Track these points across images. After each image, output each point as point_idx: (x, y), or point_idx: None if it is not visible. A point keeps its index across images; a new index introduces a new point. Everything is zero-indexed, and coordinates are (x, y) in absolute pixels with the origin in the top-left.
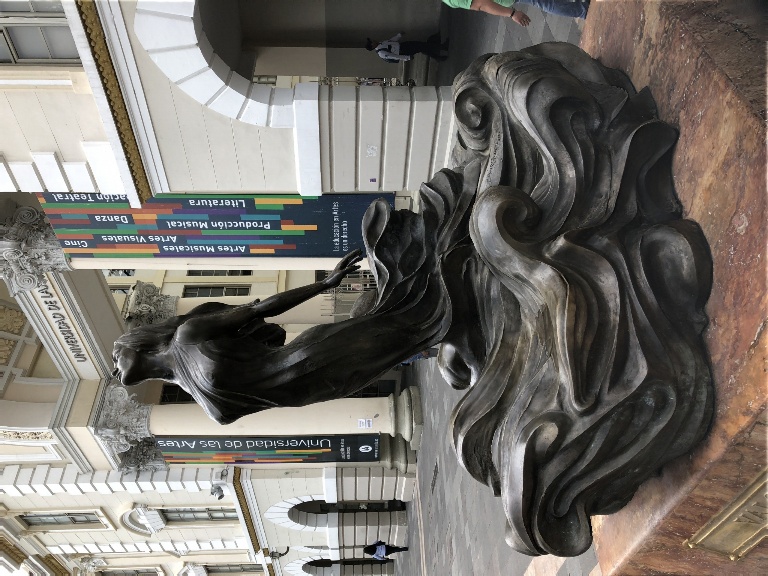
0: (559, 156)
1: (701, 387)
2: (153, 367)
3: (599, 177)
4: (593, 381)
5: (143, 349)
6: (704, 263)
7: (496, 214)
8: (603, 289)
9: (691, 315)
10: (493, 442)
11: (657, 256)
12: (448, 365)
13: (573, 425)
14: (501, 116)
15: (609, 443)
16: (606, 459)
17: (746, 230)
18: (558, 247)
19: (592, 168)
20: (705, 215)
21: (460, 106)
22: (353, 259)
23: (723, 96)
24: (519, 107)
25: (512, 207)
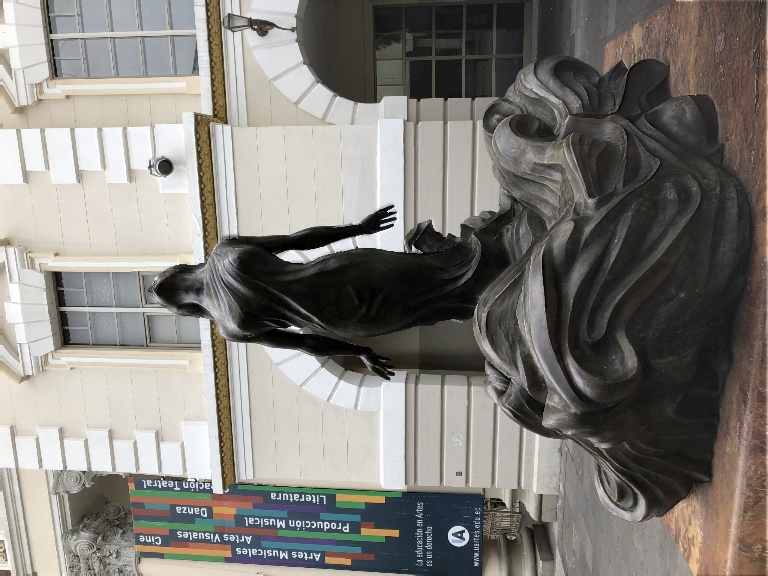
0: (566, 98)
1: (729, 188)
2: (187, 281)
3: (604, 104)
4: (607, 185)
5: (182, 270)
6: (705, 103)
7: (509, 123)
8: (611, 140)
9: (706, 150)
10: (518, 304)
11: (662, 120)
12: None
13: (590, 219)
14: (521, 112)
15: (634, 235)
16: (636, 260)
17: (724, 39)
18: (565, 125)
19: (596, 98)
20: (699, 81)
21: (488, 122)
22: (388, 217)
23: None
24: (529, 78)
25: (524, 120)
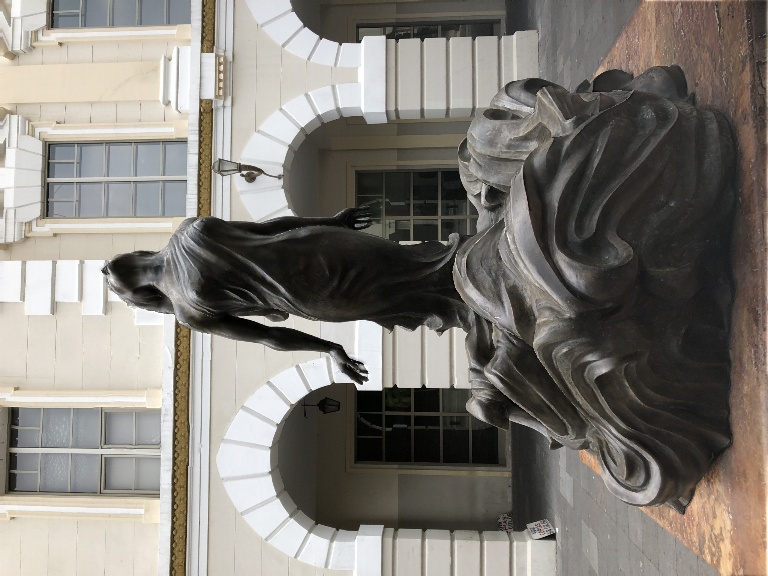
0: None
1: (705, 113)
2: (146, 260)
3: None
4: None
5: (143, 255)
6: None
7: None
8: None
9: None
10: (500, 240)
11: None
12: (472, 360)
13: None
14: None
15: (615, 144)
16: (620, 167)
17: (681, 6)
18: None
19: None
20: (662, 61)
21: (463, 153)
22: (363, 218)
23: None
24: (501, 98)
25: (498, 113)
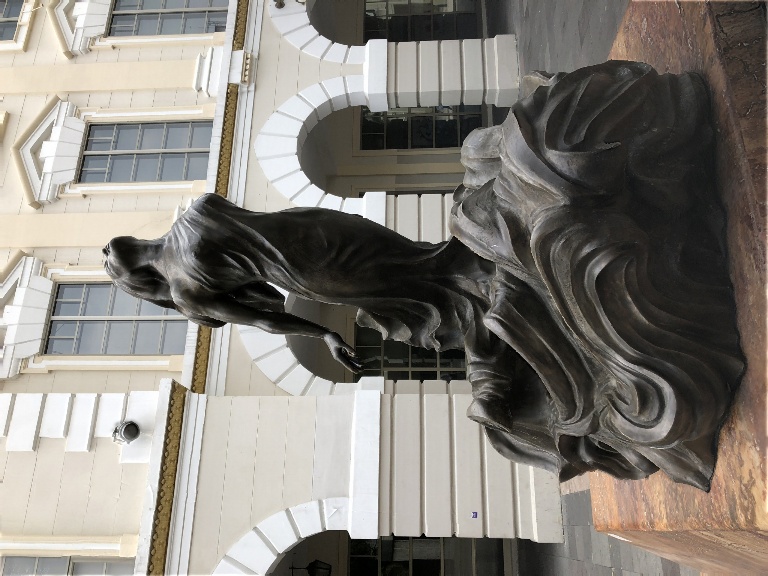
0: None
1: None
2: (148, 241)
3: None
4: None
5: None
6: None
7: None
8: None
9: None
10: (494, 182)
11: None
12: (471, 353)
13: None
14: None
15: (597, 85)
16: (603, 100)
17: (646, 20)
18: None
19: None
20: None
21: (458, 197)
22: None
23: (613, 47)
24: None
25: None
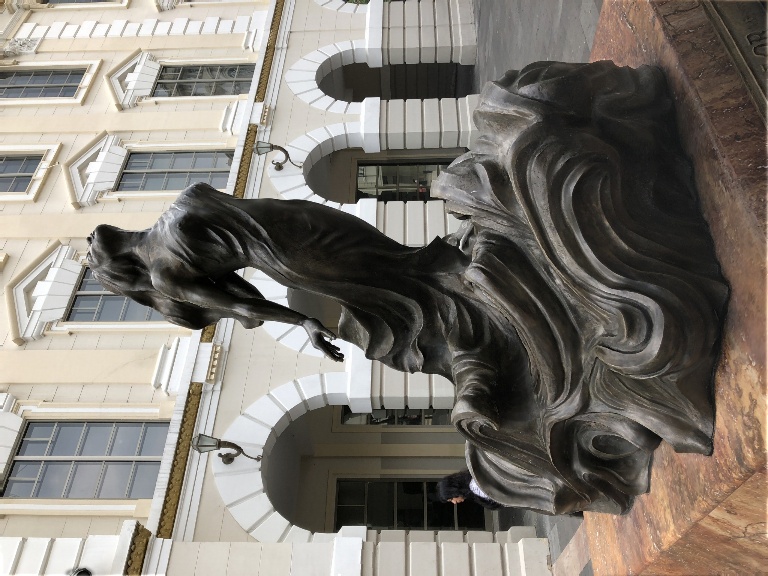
0: None
1: None
2: None
3: None
4: None
5: None
6: None
7: None
8: None
9: None
10: None
11: None
12: (454, 348)
13: None
14: None
15: None
16: None
17: (605, 59)
18: None
19: None
20: None
21: None
22: None
23: None
24: None
25: None
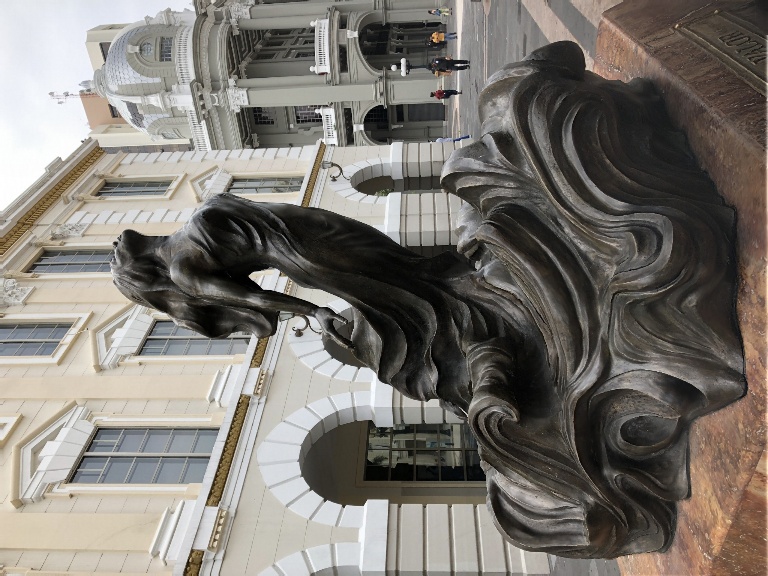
0: None
1: None
2: None
3: None
4: None
5: None
6: None
7: None
8: None
9: None
10: None
11: None
12: (469, 343)
13: None
14: None
15: None
16: None
17: None
18: None
19: None
20: None
21: None
22: None
23: None
24: None
25: None
